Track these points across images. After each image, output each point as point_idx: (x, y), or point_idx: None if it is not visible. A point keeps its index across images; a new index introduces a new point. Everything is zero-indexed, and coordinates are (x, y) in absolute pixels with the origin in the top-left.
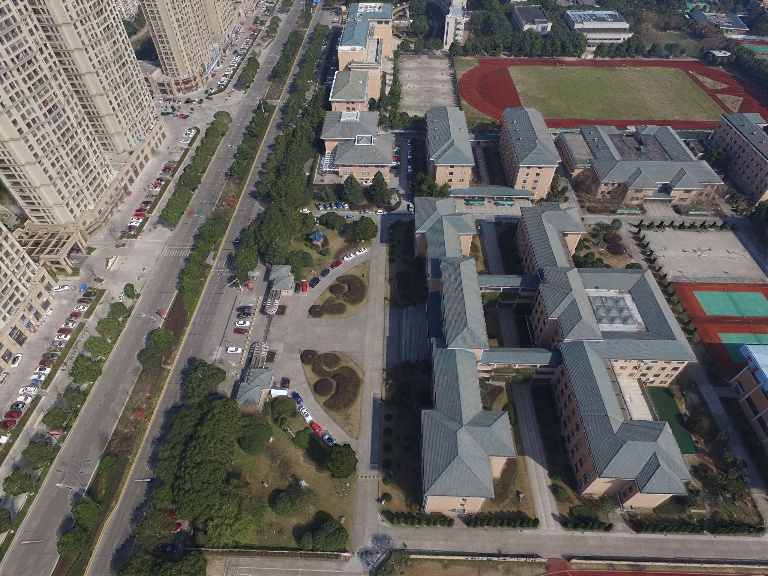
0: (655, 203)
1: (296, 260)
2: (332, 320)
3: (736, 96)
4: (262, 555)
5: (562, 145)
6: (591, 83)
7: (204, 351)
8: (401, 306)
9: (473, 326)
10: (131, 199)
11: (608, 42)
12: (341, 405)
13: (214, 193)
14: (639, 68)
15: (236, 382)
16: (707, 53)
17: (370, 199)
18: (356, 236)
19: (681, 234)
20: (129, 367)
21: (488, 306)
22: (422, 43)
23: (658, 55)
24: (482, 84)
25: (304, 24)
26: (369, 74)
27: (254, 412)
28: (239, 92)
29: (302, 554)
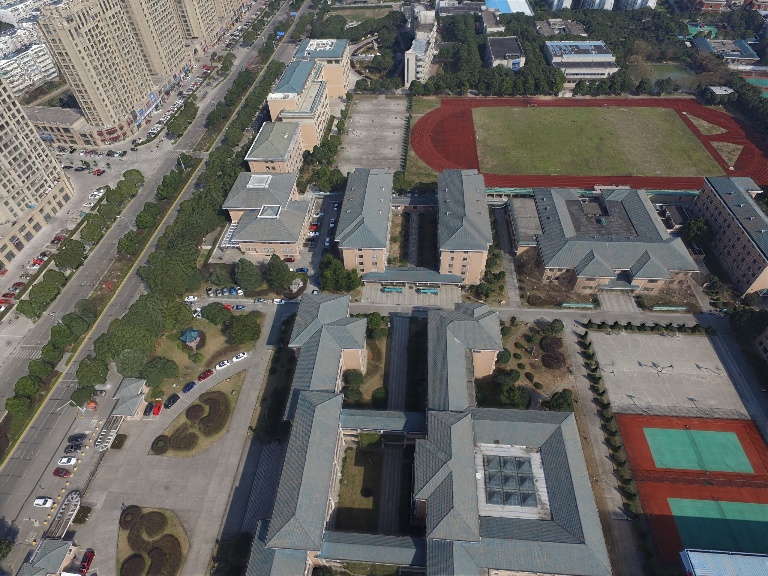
0: (613, 292)
1: (151, 373)
2: (176, 459)
3: (735, 144)
4: None
5: (510, 213)
6: (564, 128)
7: (9, 501)
8: (264, 442)
9: (304, 514)
10: (3, 279)
11: (590, 78)
12: None
13: (98, 272)
14: (623, 108)
15: (29, 553)
16: (705, 90)
17: (270, 283)
18: None
19: (640, 339)
20: None
21: (370, 447)
22: (379, 82)
23: (648, 92)
24: (438, 130)
25: (262, 60)
26: (302, 124)
27: None
28: (169, 142)
29: None
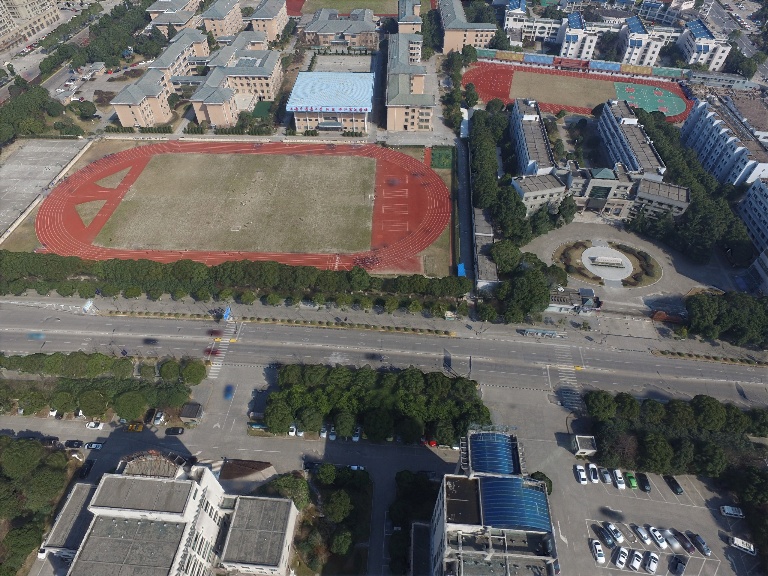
0: (339, 46)
1: (107, 59)
2: (118, 83)
3: None
4: (44, 137)
5: None
6: None
7: None
8: None
9: (163, 59)
10: (27, 43)
11: None
12: (105, 105)
13: (79, 41)
14: None
15: None
16: None
17: None
18: (147, 52)
19: (341, 57)
20: (4, 96)
21: None
22: None
23: None
24: None
25: None
26: None
27: (57, 101)
28: (119, 0)
29: (61, 136)
